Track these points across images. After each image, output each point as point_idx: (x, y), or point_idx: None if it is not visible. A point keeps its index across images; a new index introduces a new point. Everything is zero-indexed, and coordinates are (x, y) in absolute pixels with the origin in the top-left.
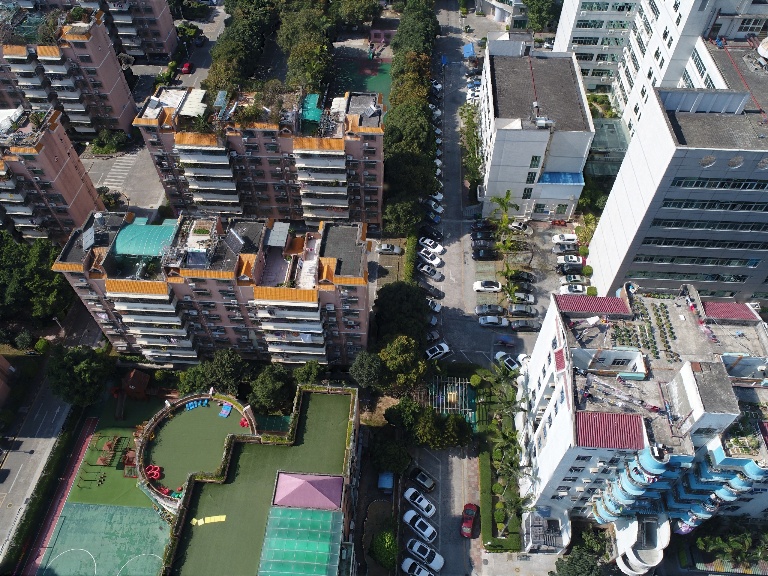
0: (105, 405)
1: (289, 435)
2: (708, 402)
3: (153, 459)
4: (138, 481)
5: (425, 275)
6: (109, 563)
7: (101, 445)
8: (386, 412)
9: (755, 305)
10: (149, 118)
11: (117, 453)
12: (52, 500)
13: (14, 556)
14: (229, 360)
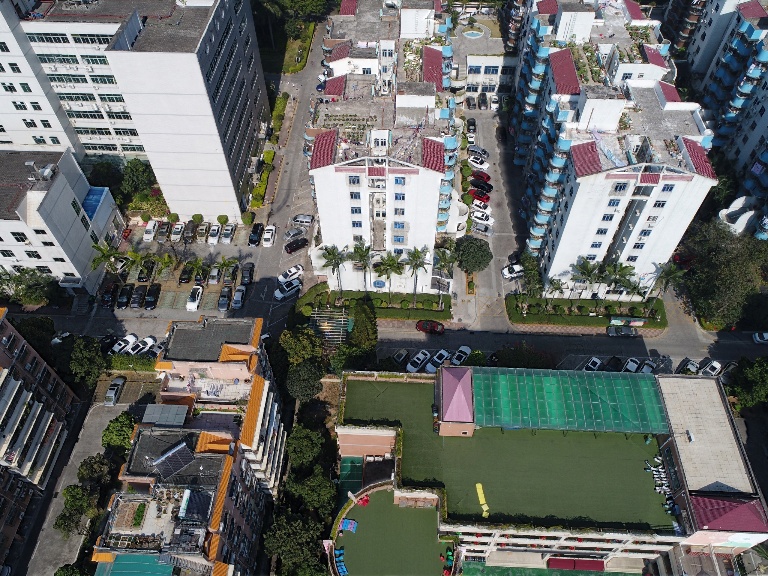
0: None
1: (396, 428)
2: (427, 94)
3: None
4: None
5: None
6: None
7: None
8: None
9: (264, 124)
10: None
11: None
12: None
13: None
14: None
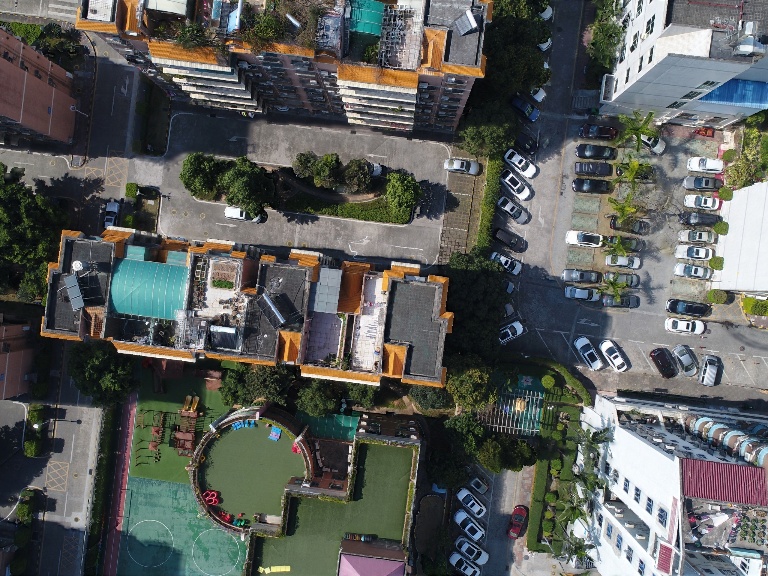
0: (141, 374)
1: (348, 498)
2: None
3: (208, 482)
4: (199, 513)
5: (506, 214)
6: (183, 535)
7: (148, 420)
8: (447, 430)
9: None
10: (100, 18)
11: (166, 429)
12: (115, 473)
13: (96, 532)
14: (273, 376)
